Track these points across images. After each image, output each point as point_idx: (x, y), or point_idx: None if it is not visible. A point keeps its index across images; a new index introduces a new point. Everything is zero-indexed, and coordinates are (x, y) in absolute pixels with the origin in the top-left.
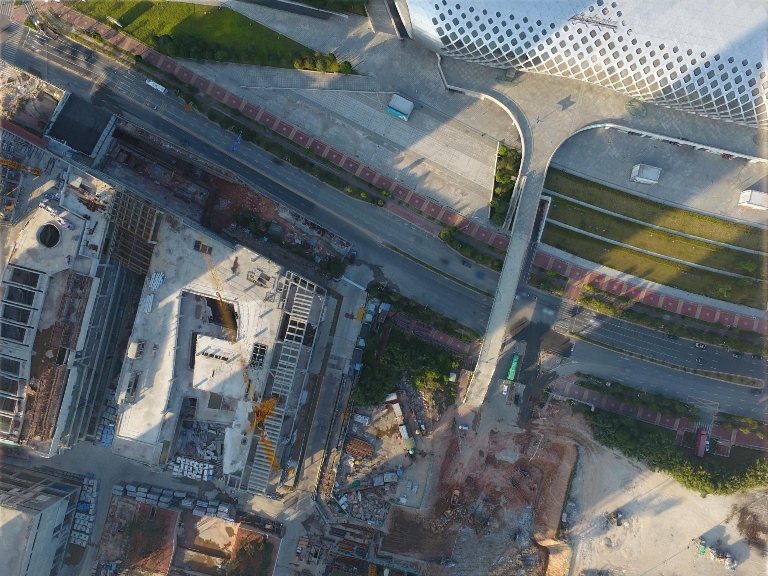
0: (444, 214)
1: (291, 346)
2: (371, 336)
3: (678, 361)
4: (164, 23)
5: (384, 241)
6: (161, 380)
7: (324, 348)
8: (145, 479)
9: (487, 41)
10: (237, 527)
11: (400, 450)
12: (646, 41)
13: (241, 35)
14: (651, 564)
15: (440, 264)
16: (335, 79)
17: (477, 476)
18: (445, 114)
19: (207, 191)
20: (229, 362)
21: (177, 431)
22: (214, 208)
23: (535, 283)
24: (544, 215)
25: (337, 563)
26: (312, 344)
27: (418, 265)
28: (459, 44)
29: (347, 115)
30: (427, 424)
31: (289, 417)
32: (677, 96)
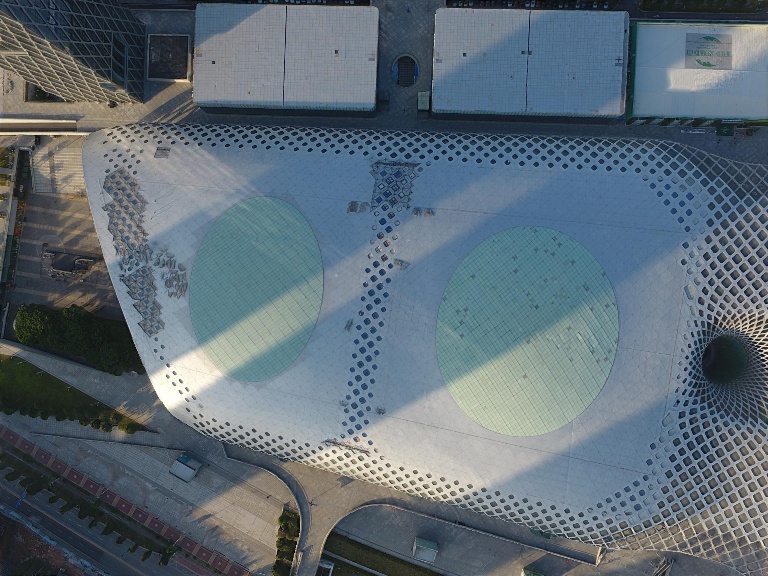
0: (231, 568)
1: None
2: None
3: None
4: None
5: None
6: None
7: None
8: None
9: (249, 445)
10: None
11: None
12: (399, 466)
13: (32, 385)
14: None
15: None
16: None
17: None
18: (231, 474)
19: (2, 527)
20: None
21: None
22: (14, 537)
23: None
24: None
25: None
26: None
27: None
28: None
29: (136, 468)
30: None
31: None
32: (441, 502)
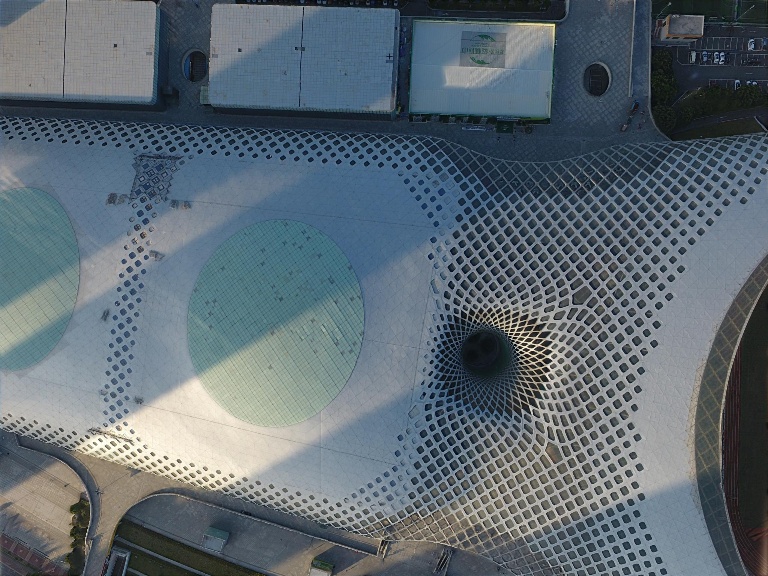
0: (32, 556)
1: None
2: None
3: None
4: None
5: None
6: None
7: None
8: None
9: (24, 434)
10: None
11: None
12: (163, 455)
13: None
14: None
15: None
16: None
17: None
18: (30, 462)
19: None
20: None
21: None
22: None
23: None
24: None
25: None
26: None
27: None
28: None
29: None
30: None
31: None
32: None
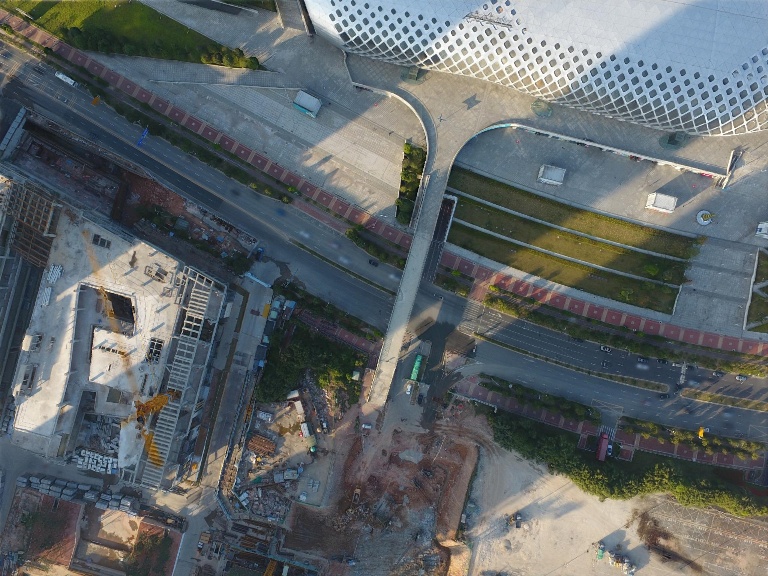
0: (351, 212)
1: (187, 341)
2: (274, 333)
3: (583, 364)
4: (75, 16)
5: (291, 238)
6: (58, 373)
7: (229, 344)
8: (50, 471)
9: (385, 38)
10: (140, 521)
11: (302, 448)
12: (541, 40)
13: (151, 29)
14: (550, 567)
15: (347, 262)
16: (244, 74)
17: (380, 475)
18: (353, 111)
19: (117, 185)
20: (125, 356)
21: (78, 424)
22: (126, 202)
23: (441, 283)
24: (451, 215)
25: (238, 559)
26: (211, 340)
27: (325, 263)
28: (358, 41)
29: (255, 111)
30: (329, 422)
31: (187, 412)
32: (577, 97)
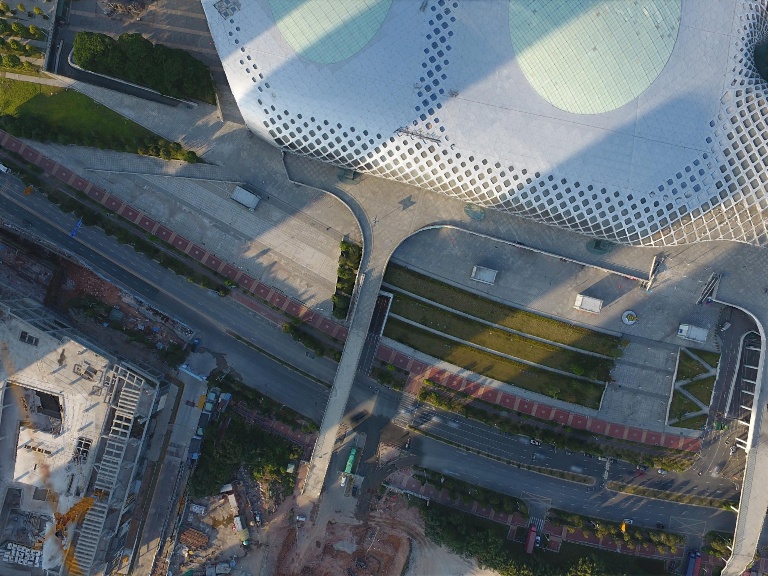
0: (289, 304)
1: (116, 441)
2: (208, 427)
3: (513, 457)
4: (9, 102)
5: (228, 329)
6: None
7: (163, 435)
8: None
9: (318, 146)
10: None
11: (235, 540)
12: (469, 156)
13: (88, 118)
14: None
15: (283, 354)
16: (182, 166)
17: (314, 566)
18: (291, 206)
19: (52, 271)
20: (52, 456)
21: (3, 520)
22: (61, 287)
23: (376, 376)
24: (387, 310)
25: None
26: (141, 437)
27: (261, 354)
28: (293, 146)
29: (194, 202)
30: (263, 515)
31: (116, 510)
32: (506, 206)
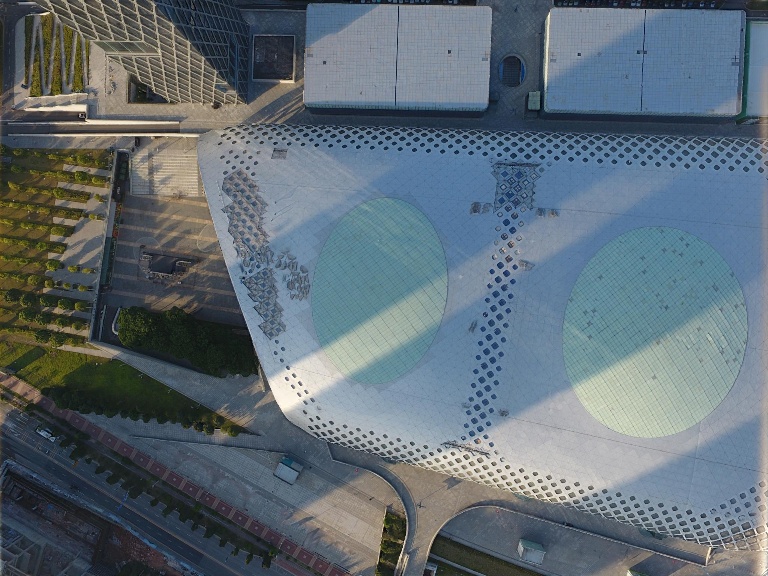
0: (332, 571)
1: None
2: None
3: None
4: (56, 371)
5: None
6: None
7: None
8: None
9: (363, 448)
10: None
11: None
12: (519, 468)
13: (132, 388)
14: None
15: None
16: (225, 434)
17: None
18: (334, 476)
19: (99, 531)
20: None
21: None
22: (108, 540)
23: None
24: None
25: None
26: None
27: None
28: None
29: (236, 470)
30: None
31: None
32: (556, 503)
